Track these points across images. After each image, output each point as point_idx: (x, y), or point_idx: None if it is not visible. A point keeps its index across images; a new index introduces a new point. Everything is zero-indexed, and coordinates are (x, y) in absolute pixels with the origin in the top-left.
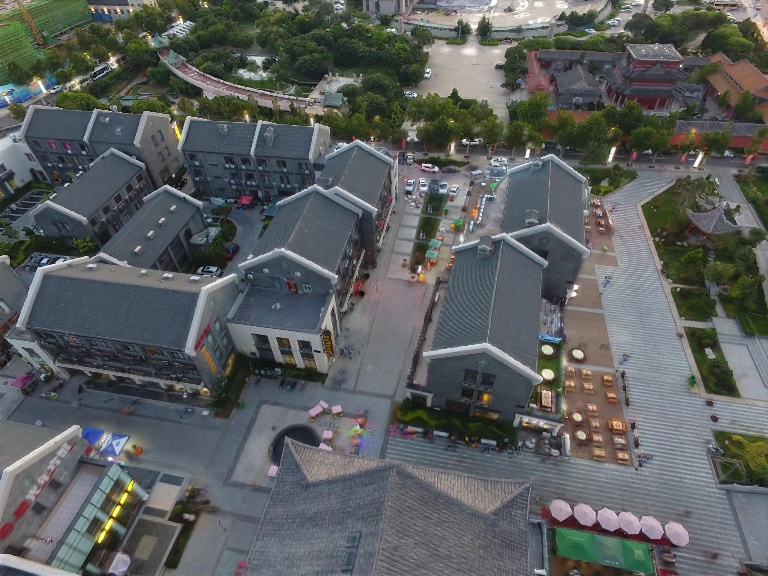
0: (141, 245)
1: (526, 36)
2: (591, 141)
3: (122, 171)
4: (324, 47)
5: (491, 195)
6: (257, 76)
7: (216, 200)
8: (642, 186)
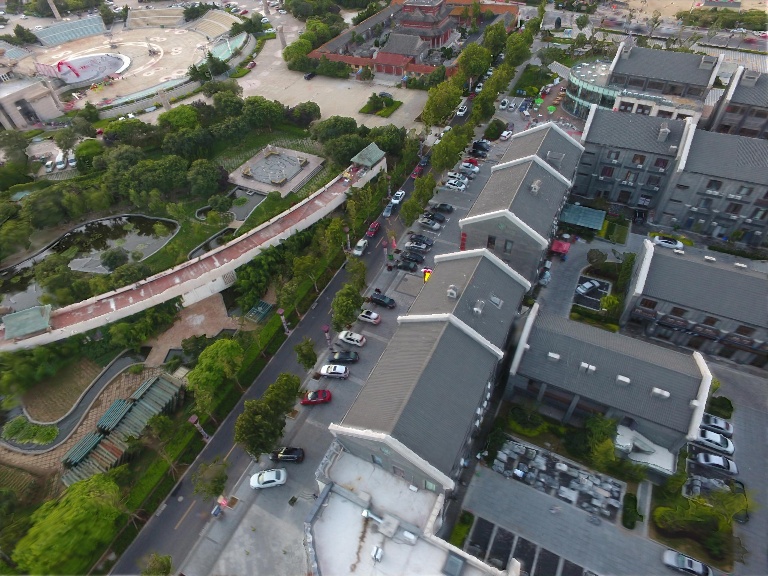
0: (761, 275)
1: (247, 55)
2: (528, 53)
3: (563, 323)
4: (171, 155)
5: (623, 90)
6: (147, 245)
7: (549, 276)
8: (550, 66)
